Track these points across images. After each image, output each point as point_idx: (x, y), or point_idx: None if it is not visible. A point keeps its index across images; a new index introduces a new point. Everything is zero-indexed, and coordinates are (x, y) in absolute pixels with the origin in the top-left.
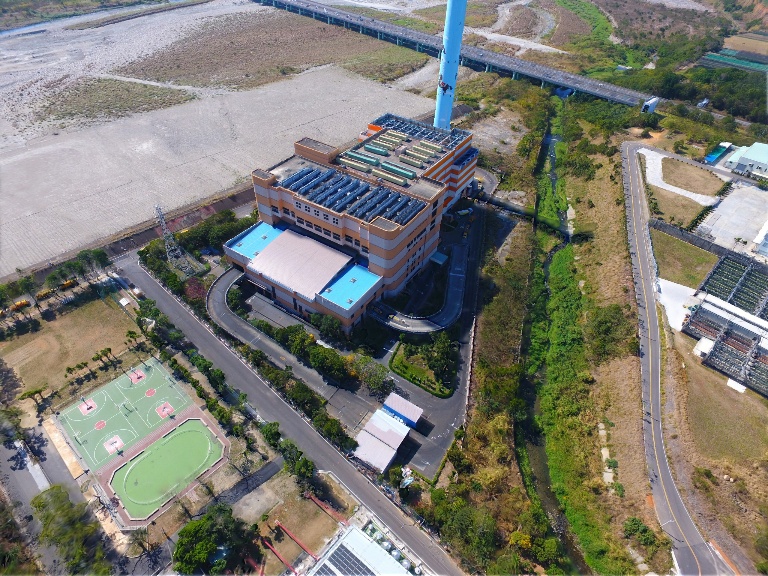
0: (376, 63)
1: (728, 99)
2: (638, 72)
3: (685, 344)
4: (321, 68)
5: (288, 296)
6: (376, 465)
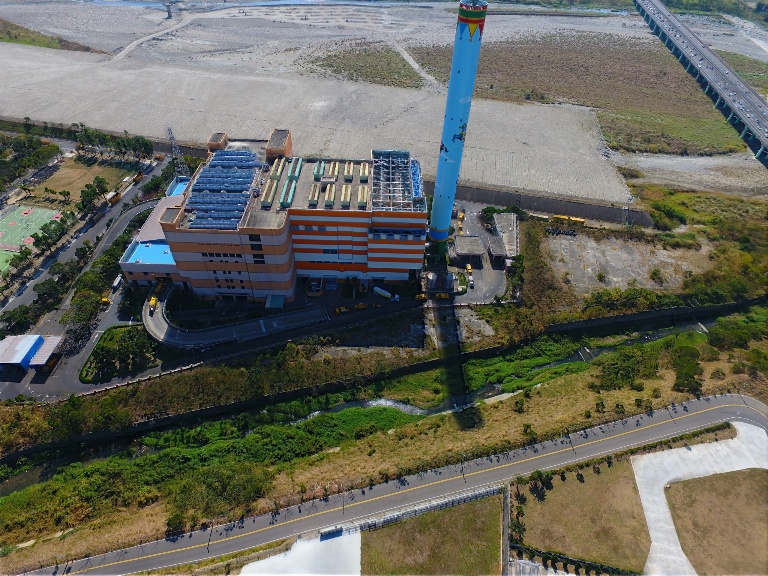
0: (650, 127)
1: None
2: None
3: None
4: (576, 108)
5: None
6: None
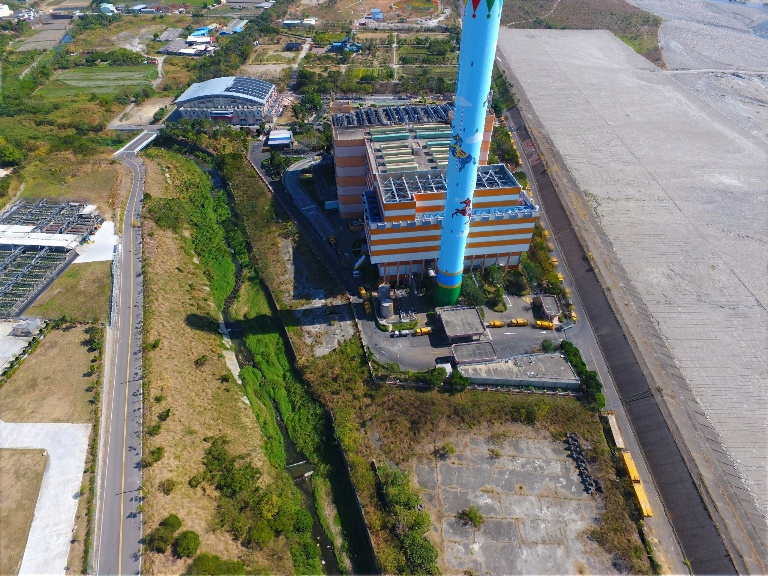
0: None
1: None
2: None
3: (104, 214)
4: None
5: None
6: None
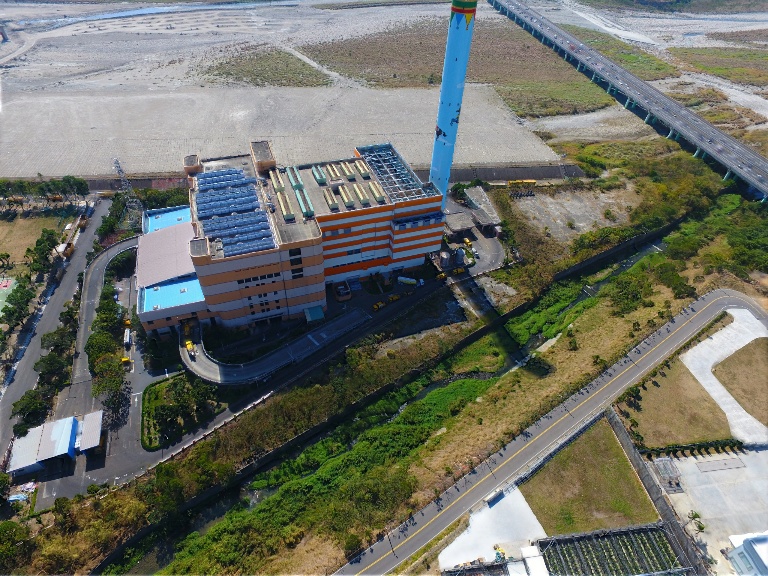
0: (540, 94)
1: None
2: None
3: None
4: (474, 86)
5: None
6: (12, 462)
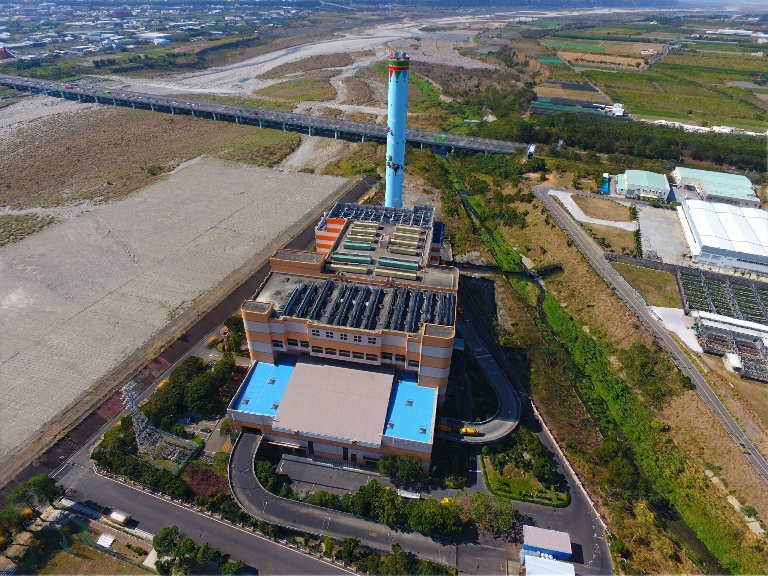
0: (250, 148)
1: (576, 137)
2: (487, 124)
3: (716, 364)
4: (193, 162)
5: (335, 447)
6: None
